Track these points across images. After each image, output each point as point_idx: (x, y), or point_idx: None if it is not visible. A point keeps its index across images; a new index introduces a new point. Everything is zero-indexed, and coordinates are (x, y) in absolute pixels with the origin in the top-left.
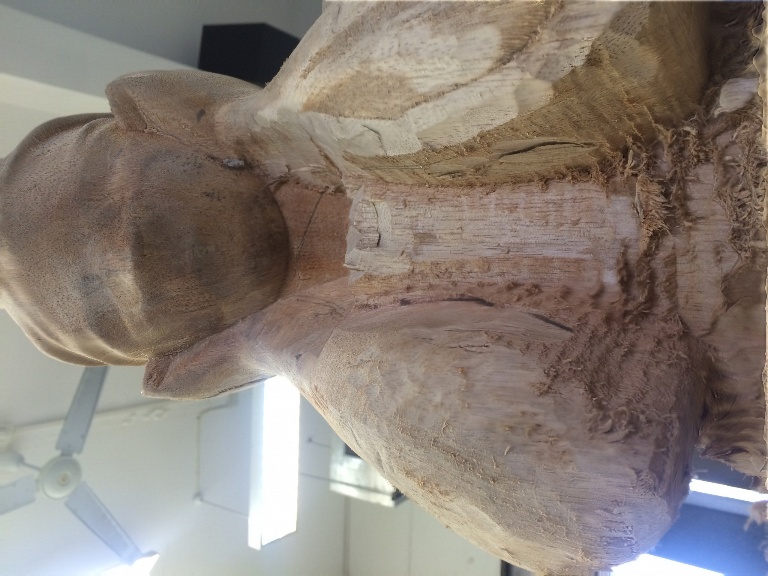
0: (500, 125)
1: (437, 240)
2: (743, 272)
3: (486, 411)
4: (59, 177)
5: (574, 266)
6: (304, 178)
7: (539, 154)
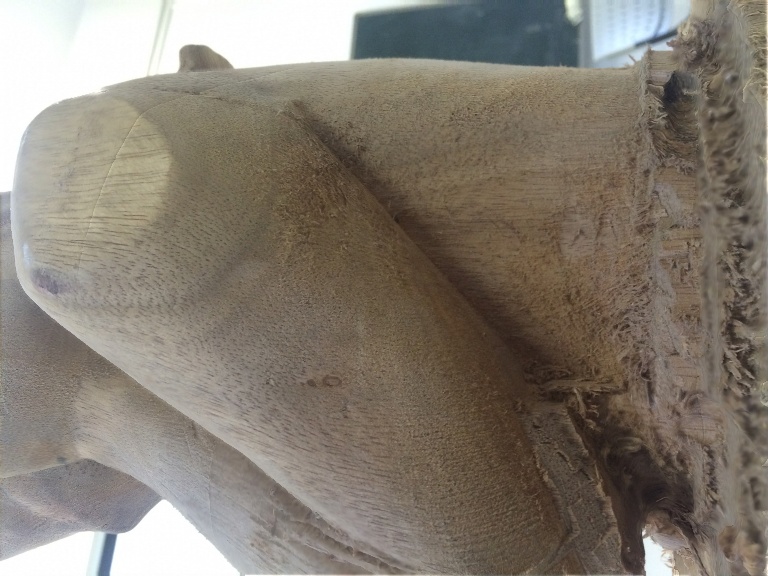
0: None
1: None
2: None
3: None
4: None
5: None
6: None
7: None
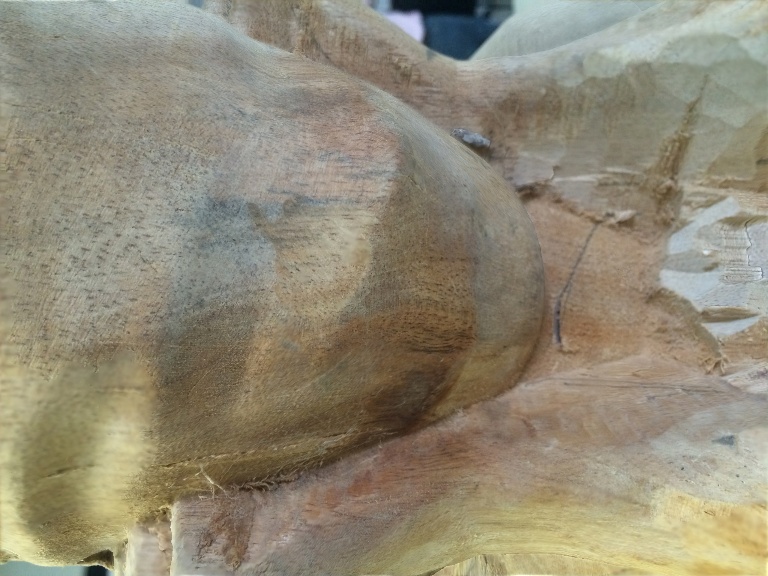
0: None
1: None
2: None
3: None
4: (165, 11)
5: None
6: (572, 195)
7: None
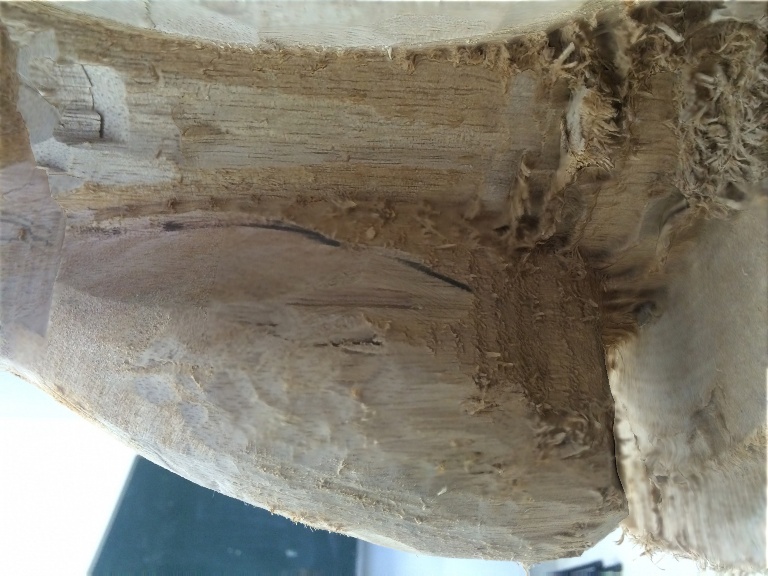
0: (445, 39)
1: (223, 136)
2: None
3: (404, 444)
4: None
5: (444, 179)
6: None
7: None
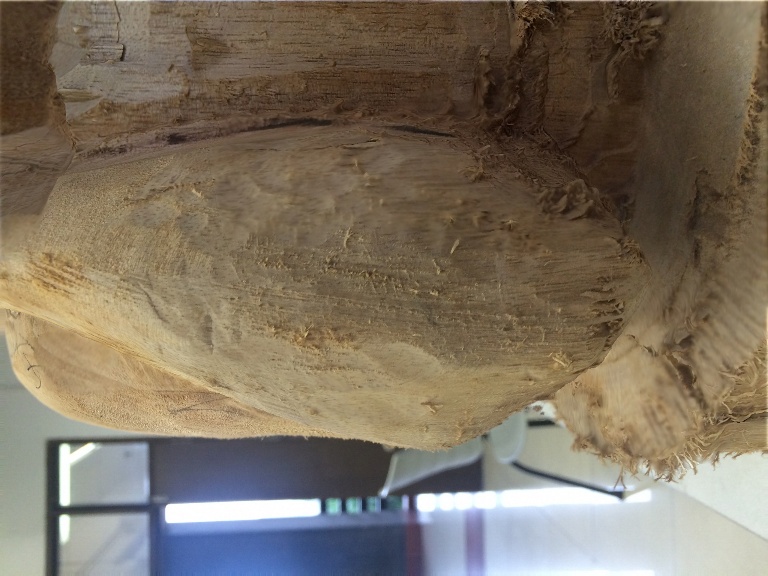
0: None
1: (228, 49)
2: (630, 58)
3: (410, 206)
4: None
5: (418, 82)
6: None
7: None
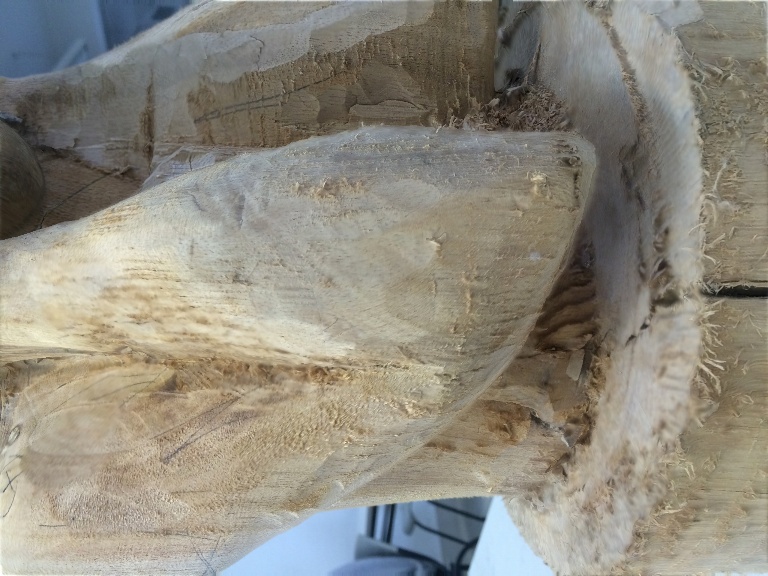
0: (387, 31)
1: None
2: None
3: None
4: None
5: None
6: (89, 158)
7: (384, 109)
